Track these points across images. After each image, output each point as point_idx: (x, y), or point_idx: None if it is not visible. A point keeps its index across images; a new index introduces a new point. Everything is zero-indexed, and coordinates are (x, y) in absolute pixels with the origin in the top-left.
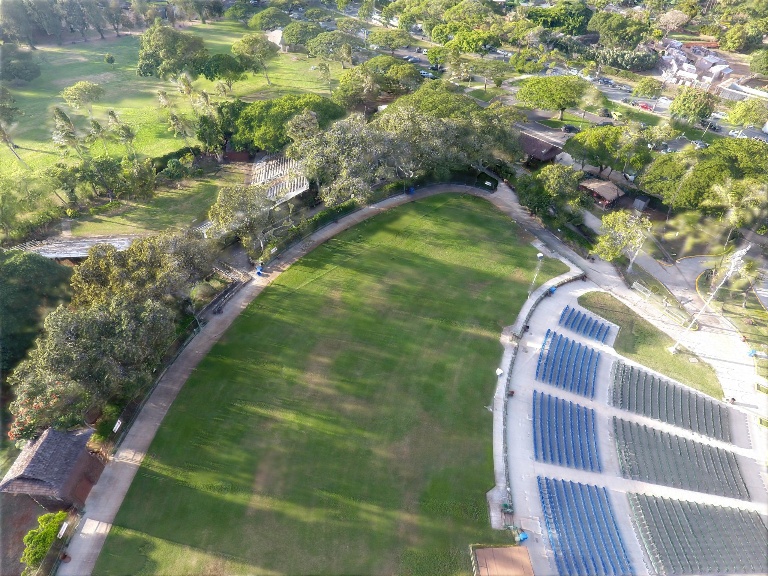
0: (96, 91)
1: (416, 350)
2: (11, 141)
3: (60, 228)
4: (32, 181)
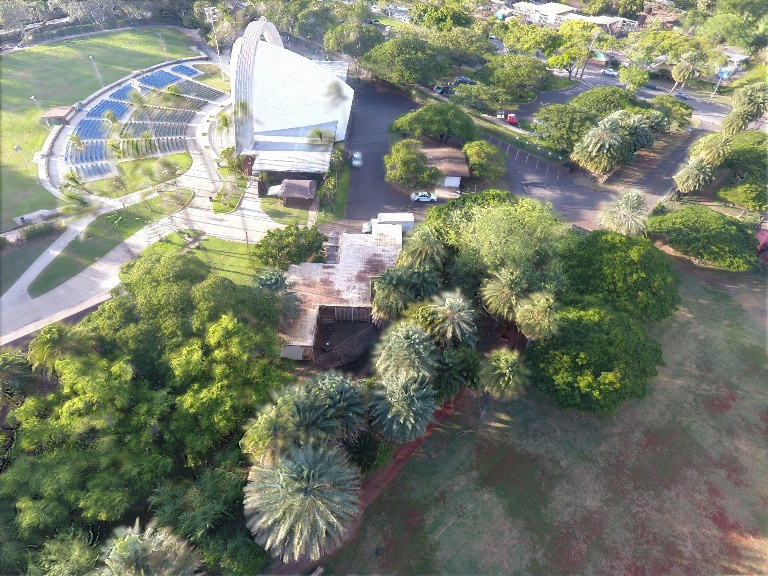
0: None
1: (83, 71)
2: None
3: None
4: None
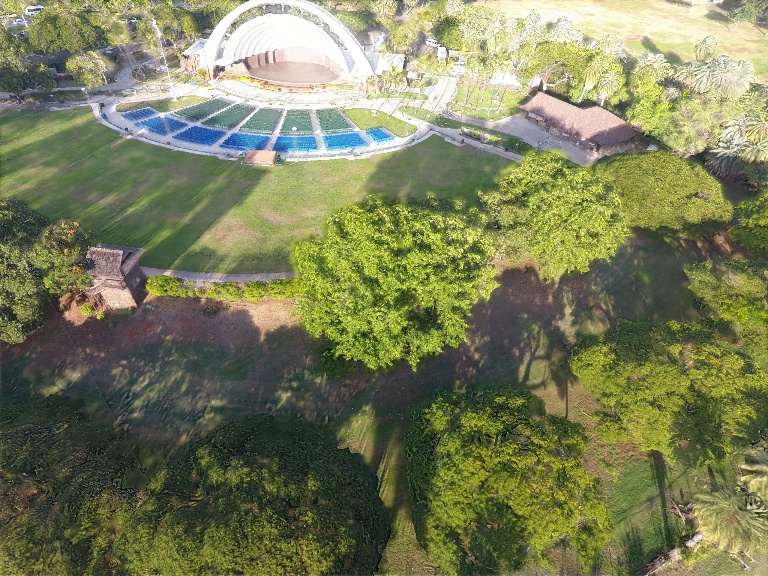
0: None
1: (113, 164)
2: None
3: None
4: None
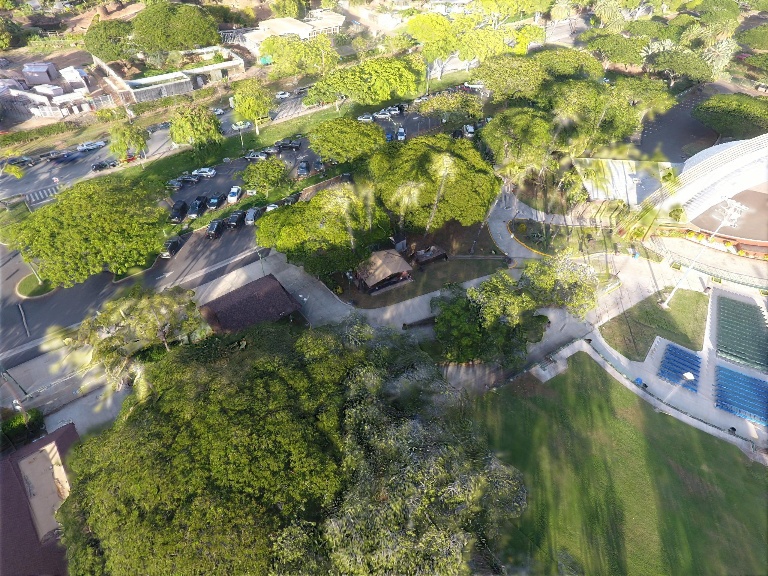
0: None
1: None
2: None
3: None
4: None
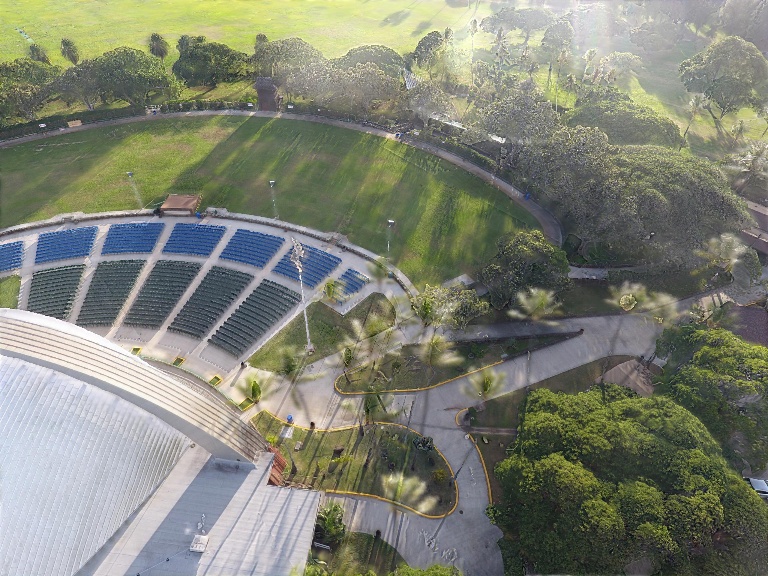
0: (626, 62)
1: (328, 192)
2: (551, 65)
3: (459, 94)
4: (461, 58)
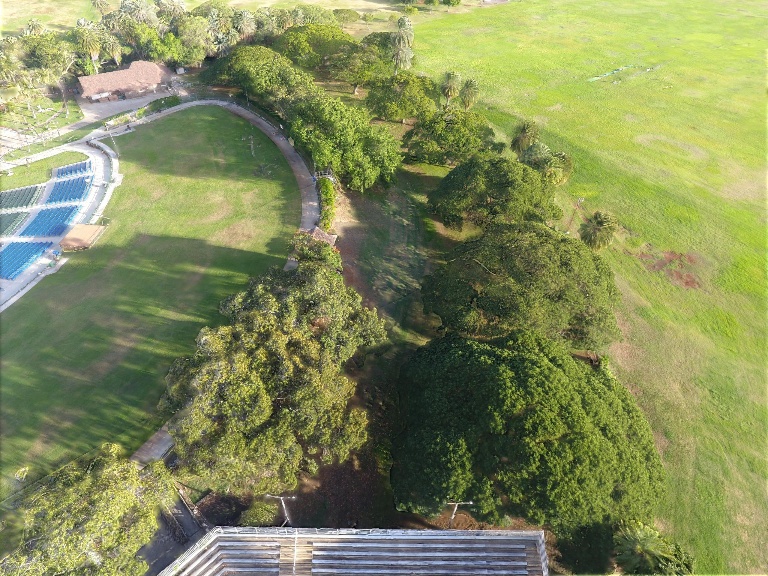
0: None
1: (8, 368)
2: None
3: None
4: None
